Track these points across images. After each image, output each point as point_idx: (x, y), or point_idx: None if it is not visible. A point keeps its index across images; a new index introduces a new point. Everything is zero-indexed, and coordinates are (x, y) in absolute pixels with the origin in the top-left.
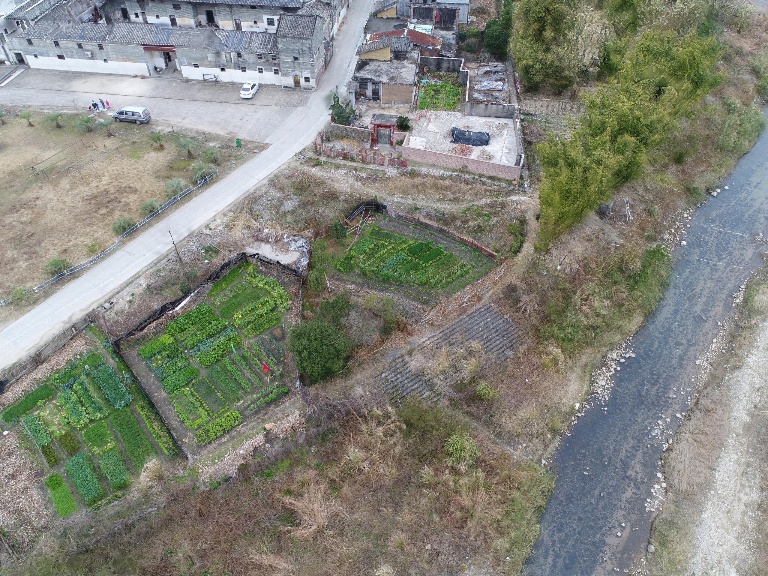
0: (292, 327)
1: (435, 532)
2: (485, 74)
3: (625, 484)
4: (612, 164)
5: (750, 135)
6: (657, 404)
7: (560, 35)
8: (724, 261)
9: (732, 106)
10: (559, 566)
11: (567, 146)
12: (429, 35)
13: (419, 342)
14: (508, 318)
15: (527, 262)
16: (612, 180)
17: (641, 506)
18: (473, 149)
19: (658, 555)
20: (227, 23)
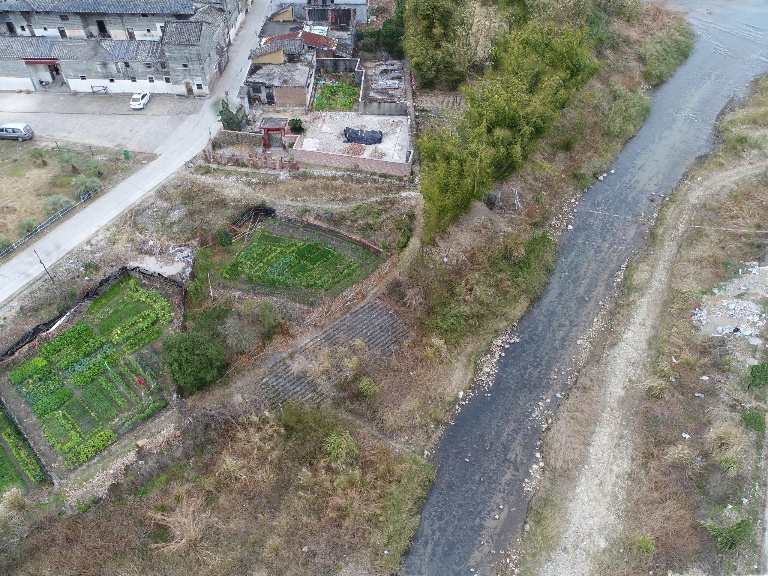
0: (163, 339)
1: (313, 533)
2: (382, 73)
3: (505, 467)
4: (493, 155)
5: (635, 120)
6: (539, 386)
7: (450, 31)
8: (607, 242)
9: (617, 93)
10: (438, 554)
11: (444, 140)
12: (324, 36)
13: (301, 344)
14: (393, 313)
15: (413, 256)
16: (496, 171)
17: (519, 487)
18: (366, 148)
19: (532, 533)
20: (119, 33)
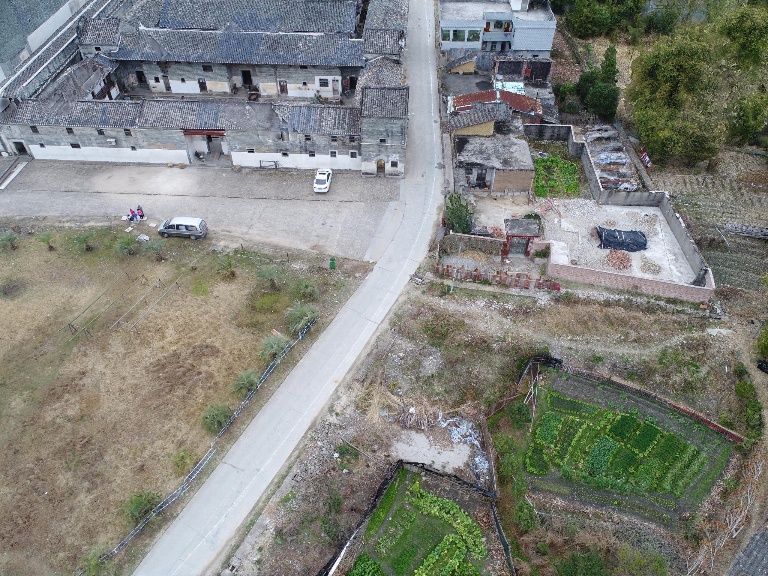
0: None
1: None
2: (595, 141)
3: None
4: None
5: None
6: None
7: (694, 96)
8: None
9: None
10: None
11: None
12: (524, 96)
13: None
14: None
15: None
16: None
17: None
18: (631, 257)
19: None
20: (270, 85)
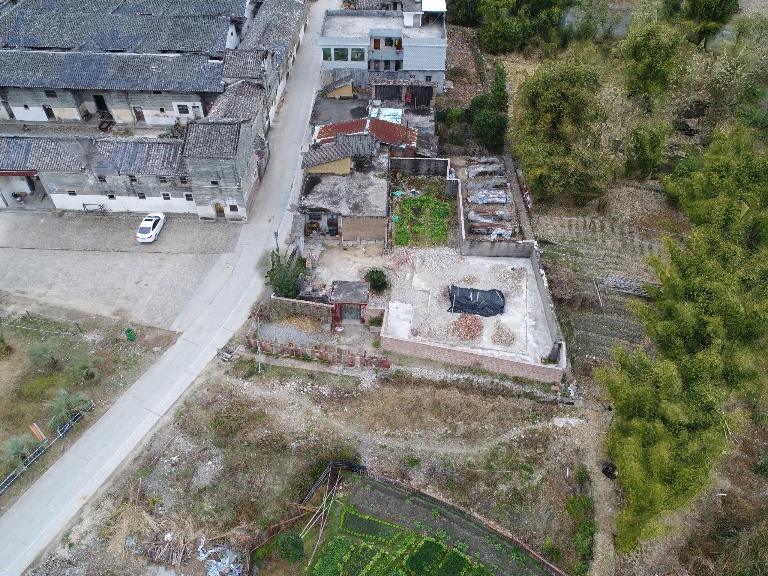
0: None
1: None
2: (478, 176)
3: None
4: None
5: None
6: None
7: (580, 127)
8: None
9: None
10: None
11: (659, 382)
12: (399, 125)
13: None
14: None
15: None
16: None
17: None
18: (483, 323)
19: None
20: (123, 112)
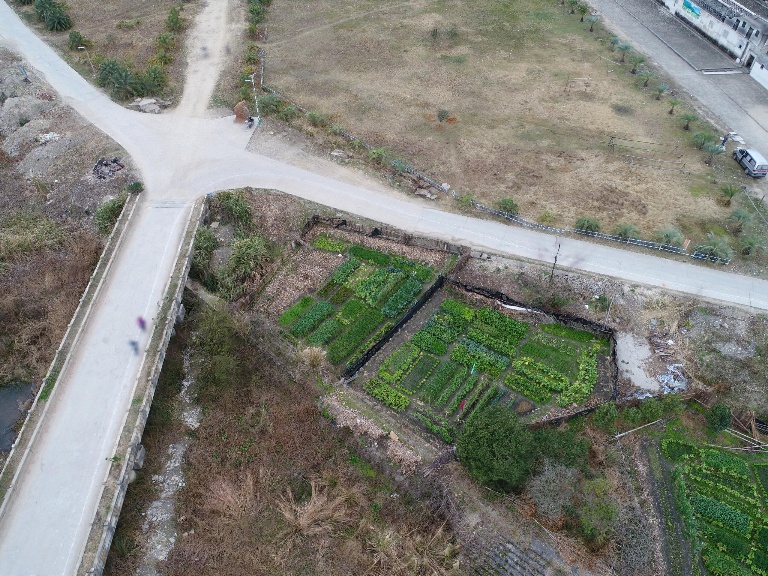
0: None
1: None
2: None
3: None
4: None
5: None
6: None
7: None
8: None
9: None
10: None
11: None
12: None
13: None
14: None
15: None
16: None
17: None
18: None
19: None
20: None
